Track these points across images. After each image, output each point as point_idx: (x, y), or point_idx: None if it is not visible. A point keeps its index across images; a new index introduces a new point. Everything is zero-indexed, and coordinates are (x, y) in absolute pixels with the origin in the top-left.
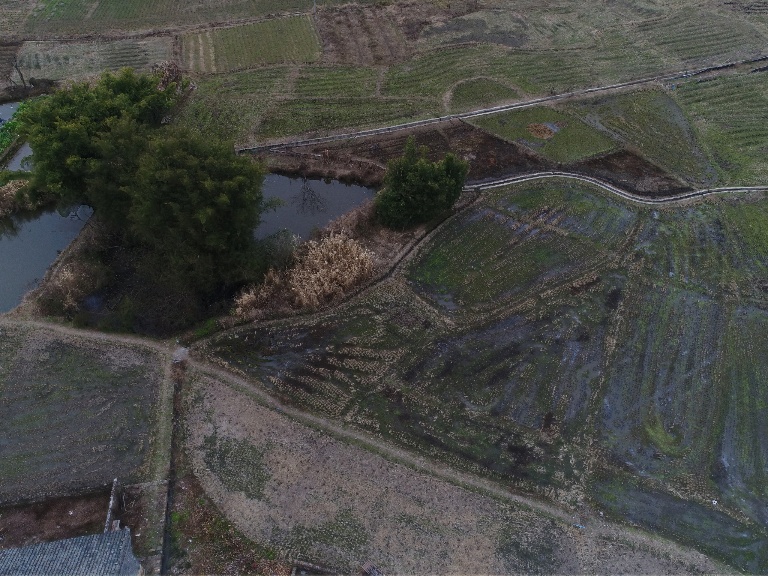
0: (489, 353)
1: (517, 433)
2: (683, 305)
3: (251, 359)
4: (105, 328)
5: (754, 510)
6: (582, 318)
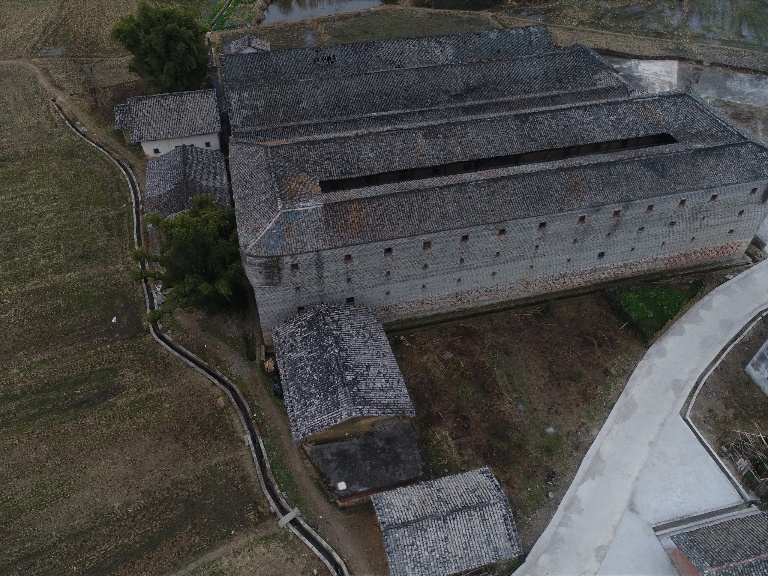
0: (631, 13)
1: (655, 29)
2: (715, 1)
3: (523, 16)
4: (450, 7)
5: (758, 42)
6: (669, 4)
